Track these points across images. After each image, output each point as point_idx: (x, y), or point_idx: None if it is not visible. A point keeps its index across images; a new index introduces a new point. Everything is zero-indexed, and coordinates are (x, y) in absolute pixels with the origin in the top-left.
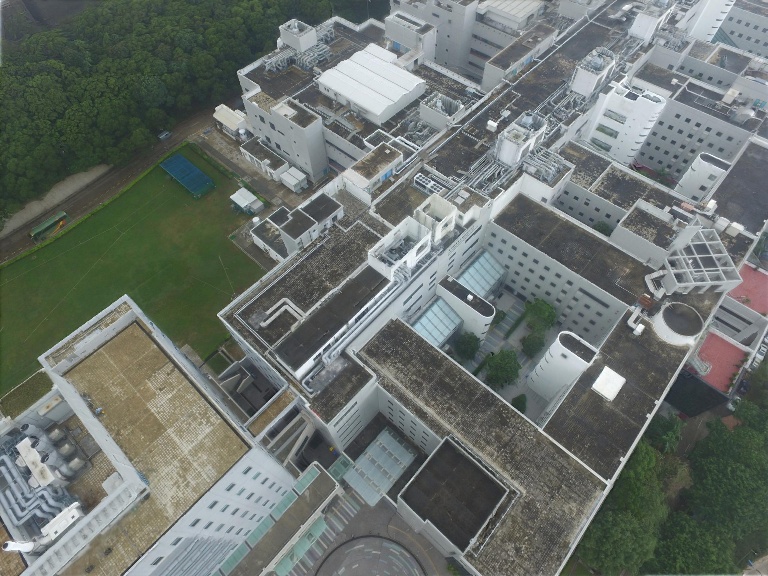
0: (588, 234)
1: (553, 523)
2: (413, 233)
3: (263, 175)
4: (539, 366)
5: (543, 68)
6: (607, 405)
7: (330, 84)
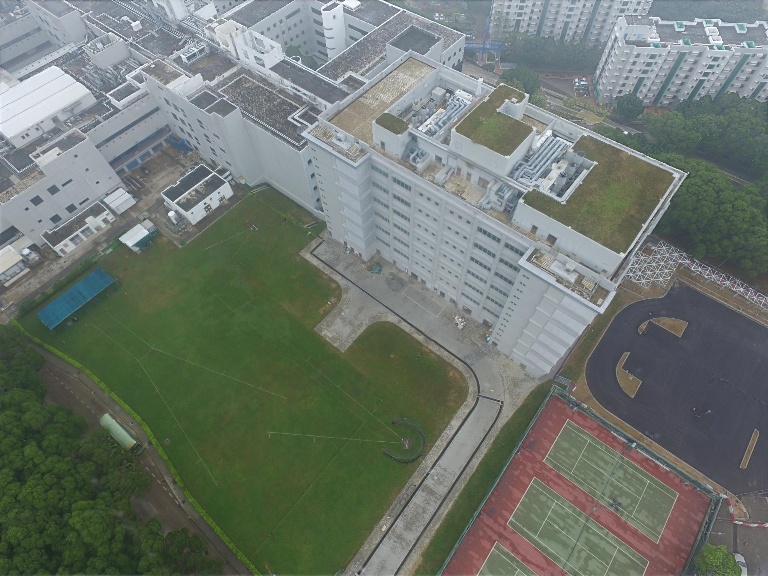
0: (247, 6)
1: (423, 27)
2: (243, 51)
3: (101, 233)
4: (332, 51)
5: (74, 2)
6: (363, 8)
7: (23, 127)
